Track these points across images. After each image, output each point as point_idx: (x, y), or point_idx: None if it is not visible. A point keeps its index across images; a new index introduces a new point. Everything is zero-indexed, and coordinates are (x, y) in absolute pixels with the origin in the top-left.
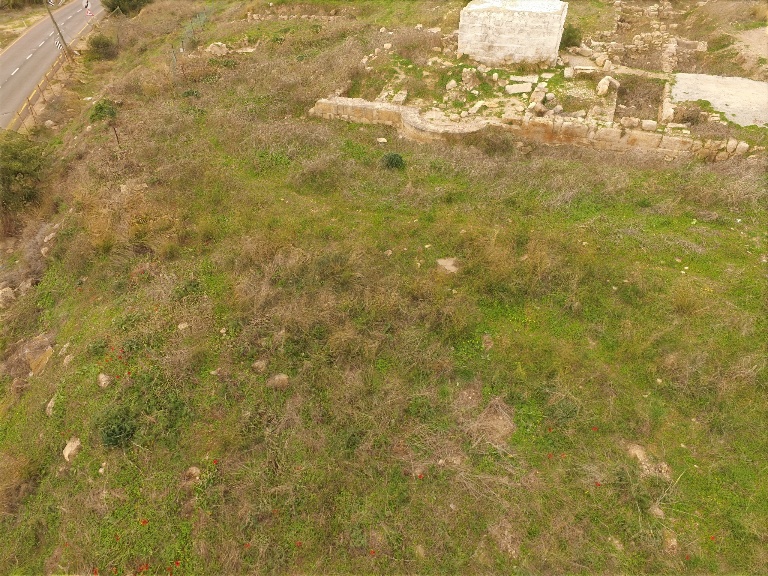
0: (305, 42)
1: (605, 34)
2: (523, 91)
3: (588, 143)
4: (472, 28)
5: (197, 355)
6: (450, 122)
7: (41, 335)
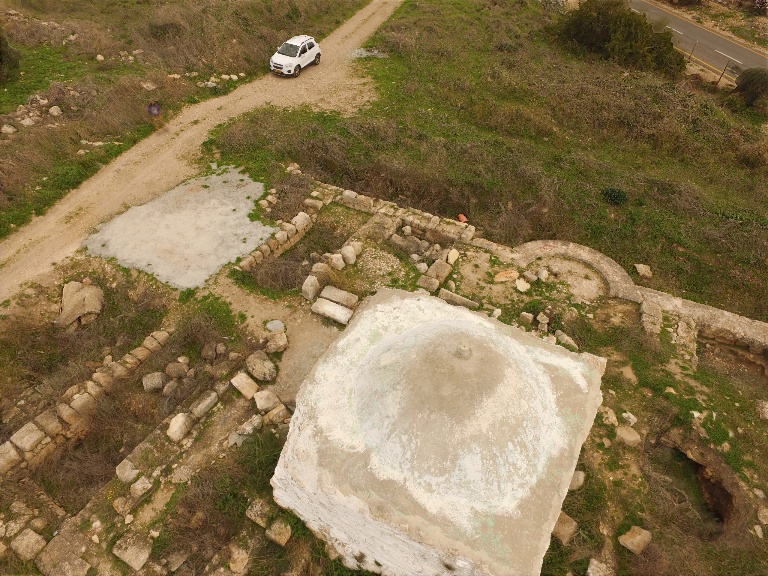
0: None
1: None
2: None
3: None
4: None
5: None
6: None
7: None
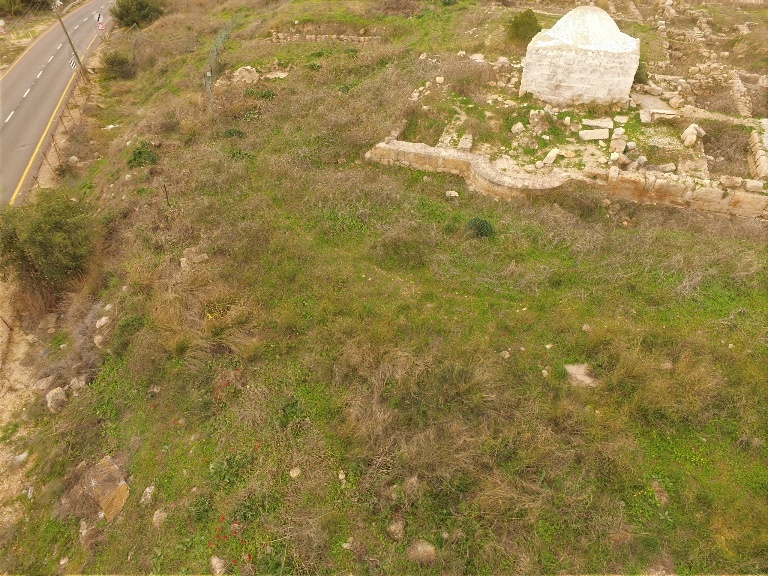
0: (344, 70)
1: (660, 65)
2: (599, 138)
3: (683, 202)
4: (539, 66)
5: (327, 525)
6: (526, 174)
7: (108, 460)
